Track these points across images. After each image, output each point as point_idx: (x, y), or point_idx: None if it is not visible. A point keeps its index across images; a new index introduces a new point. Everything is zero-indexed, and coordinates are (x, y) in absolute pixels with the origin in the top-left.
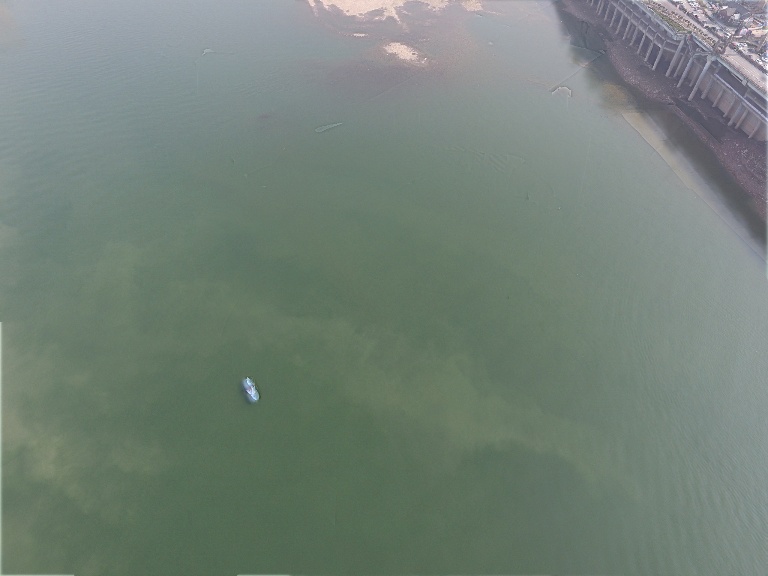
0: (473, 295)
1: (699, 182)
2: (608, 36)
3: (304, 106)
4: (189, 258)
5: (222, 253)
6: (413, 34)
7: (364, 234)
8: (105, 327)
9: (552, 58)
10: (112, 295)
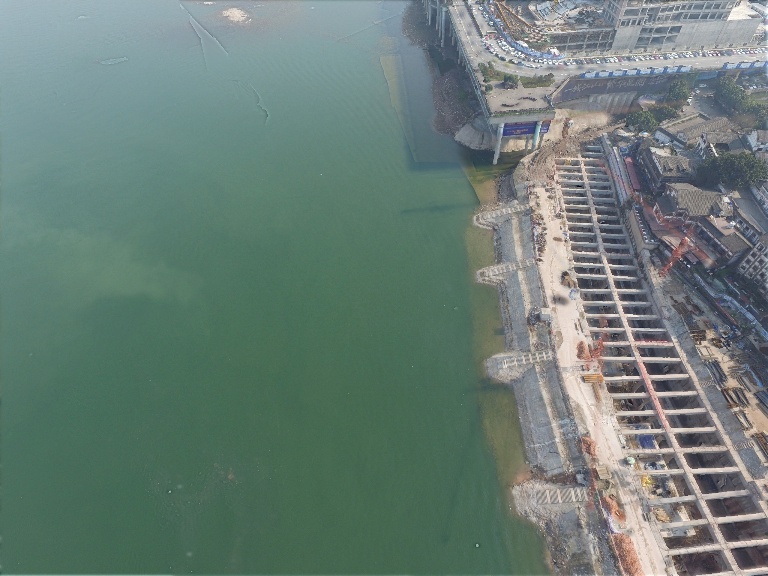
0: (186, 177)
1: (403, 102)
2: (413, 1)
3: (130, 54)
4: None
5: (6, 148)
6: (253, 2)
7: (130, 140)
8: None
9: (357, 18)
10: None
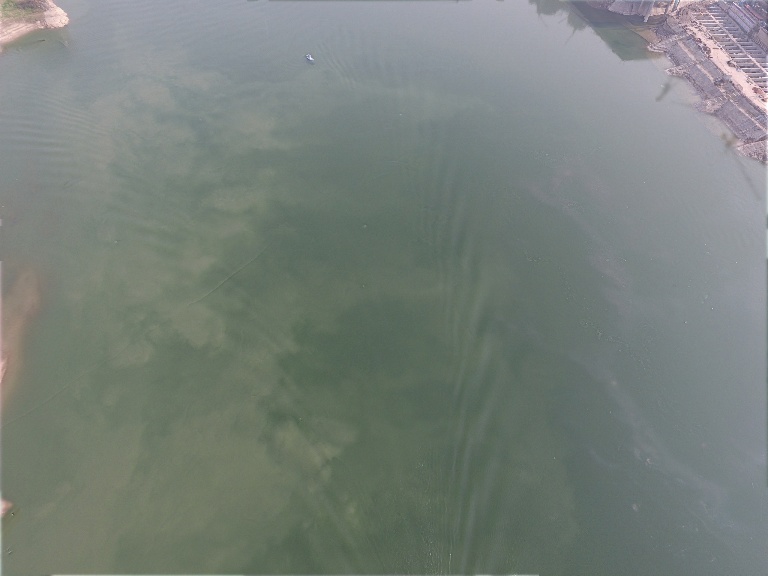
0: (423, 35)
1: None
2: None
3: None
4: (265, 19)
5: (283, 17)
6: None
7: (362, 18)
8: (221, 53)
9: None
10: (224, 36)
